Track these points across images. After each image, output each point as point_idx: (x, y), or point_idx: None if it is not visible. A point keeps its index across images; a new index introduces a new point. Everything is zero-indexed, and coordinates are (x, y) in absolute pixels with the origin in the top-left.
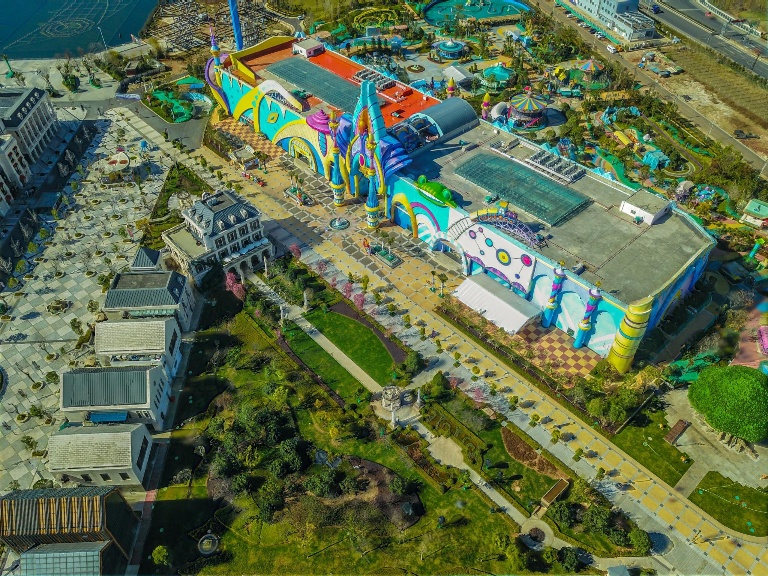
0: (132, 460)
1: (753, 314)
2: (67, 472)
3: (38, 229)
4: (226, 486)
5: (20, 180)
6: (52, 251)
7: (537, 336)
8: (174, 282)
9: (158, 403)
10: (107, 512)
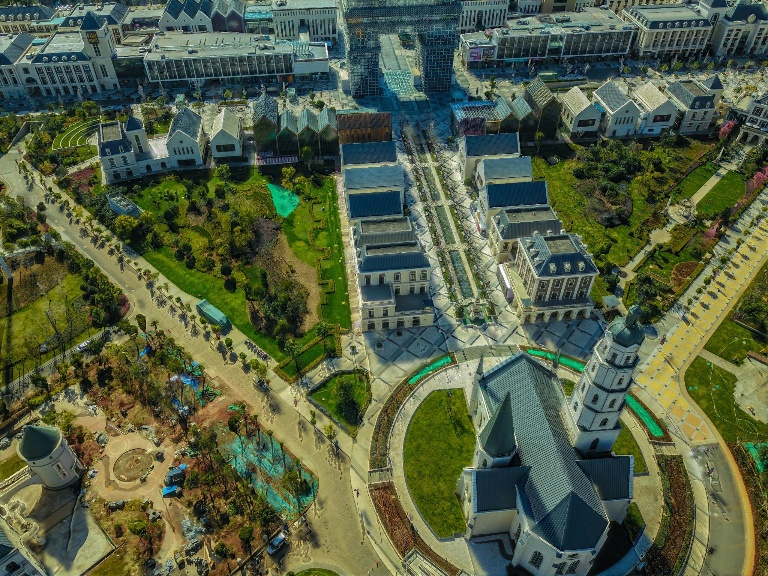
0: (579, 114)
1: None
2: (563, 102)
3: (717, 69)
4: (584, 150)
5: (751, 49)
6: (703, 77)
7: None
8: (704, 100)
9: (619, 123)
10: (549, 106)
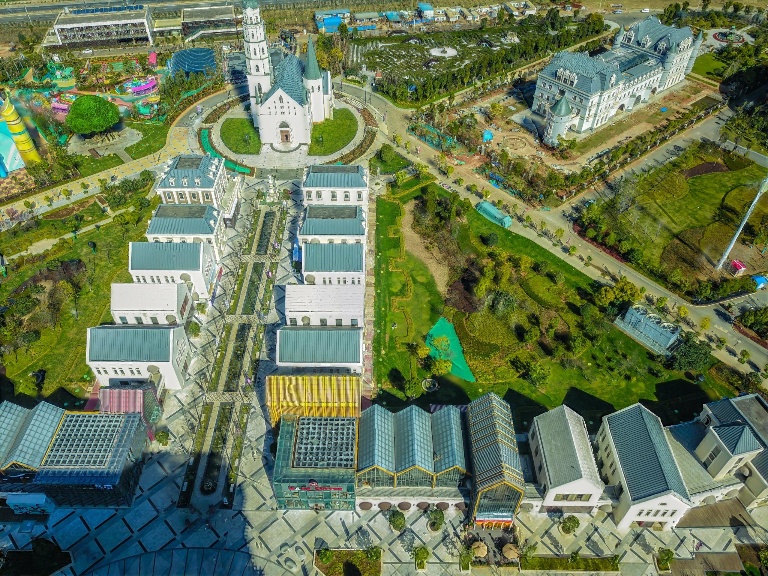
0: None
1: (43, 94)
2: None
3: None
4: None
5: None
6: None
7: None
8: None
9: None
10: None
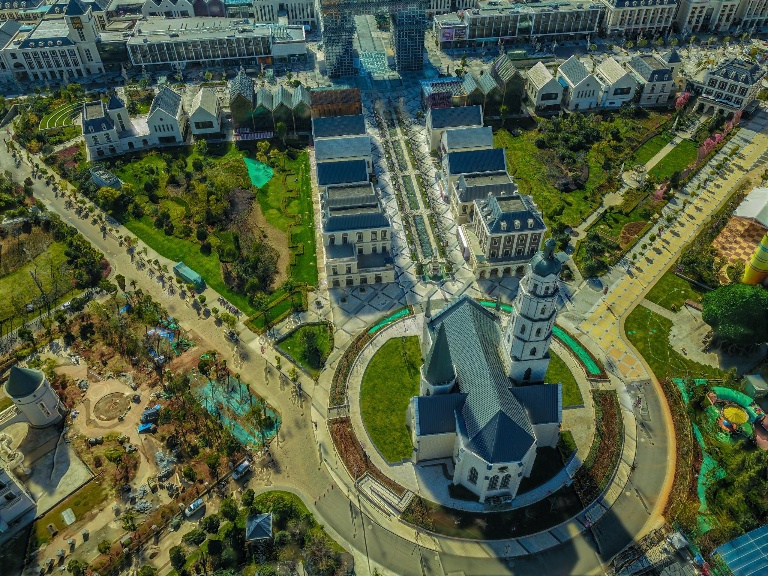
0: (542, 88)
1: None
2: (528, 77)
3: (681, 45)
4: (545, 122)
5: (716, 25)
6: None
7: (751, 241)
8: (662, 73)
9: (581, 96)
10: (513, 81)
